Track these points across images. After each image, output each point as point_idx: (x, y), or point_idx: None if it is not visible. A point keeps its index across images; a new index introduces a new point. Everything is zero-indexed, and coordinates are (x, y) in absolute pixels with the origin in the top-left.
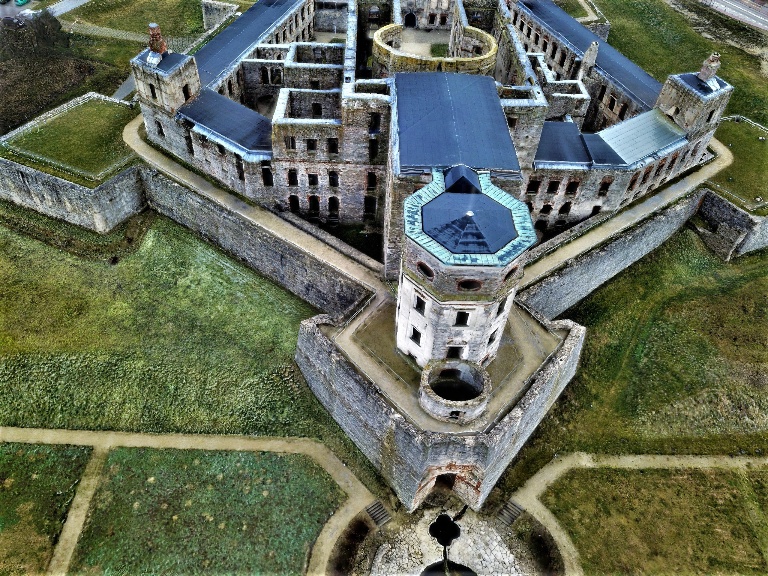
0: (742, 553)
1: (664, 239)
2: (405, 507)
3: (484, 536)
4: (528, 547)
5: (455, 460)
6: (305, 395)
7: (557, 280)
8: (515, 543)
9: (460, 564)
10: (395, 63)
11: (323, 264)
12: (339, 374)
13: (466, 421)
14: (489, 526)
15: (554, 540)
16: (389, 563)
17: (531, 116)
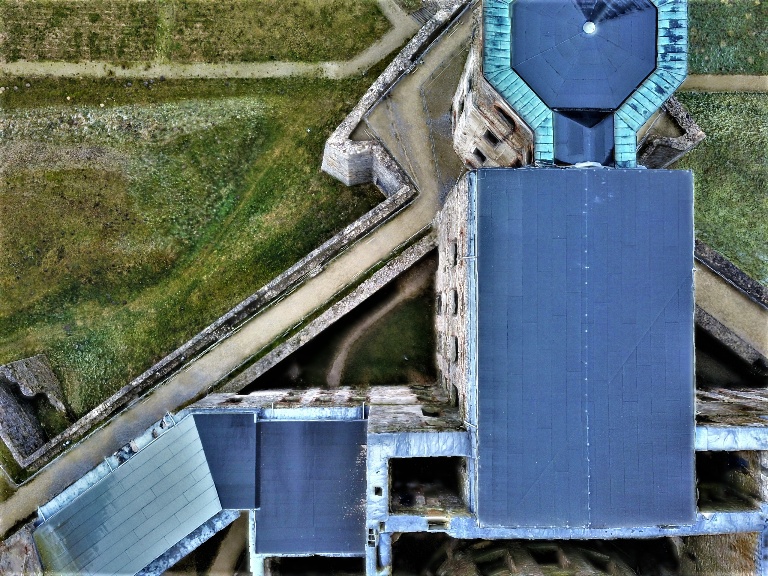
0: None
1: None
2: None
3: None
4: None
5: None
6: None
7: (347, 228)
8: None
9: None
10: None
11: None
12: None
13: None
14: None
15: None
16: None
17: None
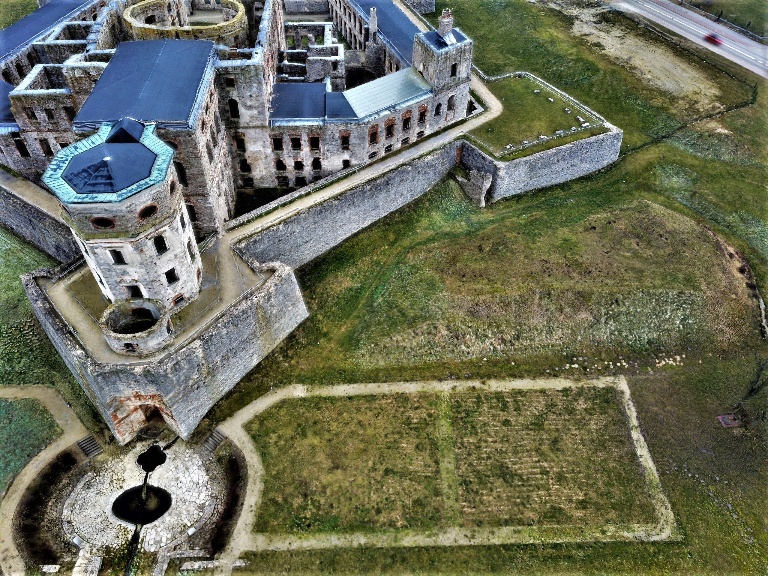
0: (419, 464)
1: (425, 190)
2: (117, 440)
3: (187, 462)
4: (224, 469)
5: (137, 390)
6: (44, 346)
7: (281, 228)
8: (214, 466)
9: (158, 487)
10: (138, 34)
11: (61, 224)
12: (45, 320)
13: (146, 354)
14: (194, 453)
15: (246, 461)
16: (90, 489)
17: (246, 75)
